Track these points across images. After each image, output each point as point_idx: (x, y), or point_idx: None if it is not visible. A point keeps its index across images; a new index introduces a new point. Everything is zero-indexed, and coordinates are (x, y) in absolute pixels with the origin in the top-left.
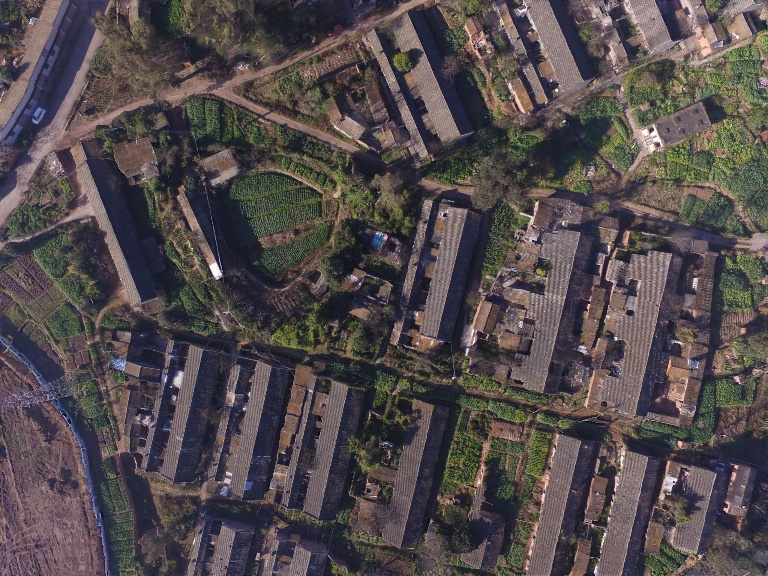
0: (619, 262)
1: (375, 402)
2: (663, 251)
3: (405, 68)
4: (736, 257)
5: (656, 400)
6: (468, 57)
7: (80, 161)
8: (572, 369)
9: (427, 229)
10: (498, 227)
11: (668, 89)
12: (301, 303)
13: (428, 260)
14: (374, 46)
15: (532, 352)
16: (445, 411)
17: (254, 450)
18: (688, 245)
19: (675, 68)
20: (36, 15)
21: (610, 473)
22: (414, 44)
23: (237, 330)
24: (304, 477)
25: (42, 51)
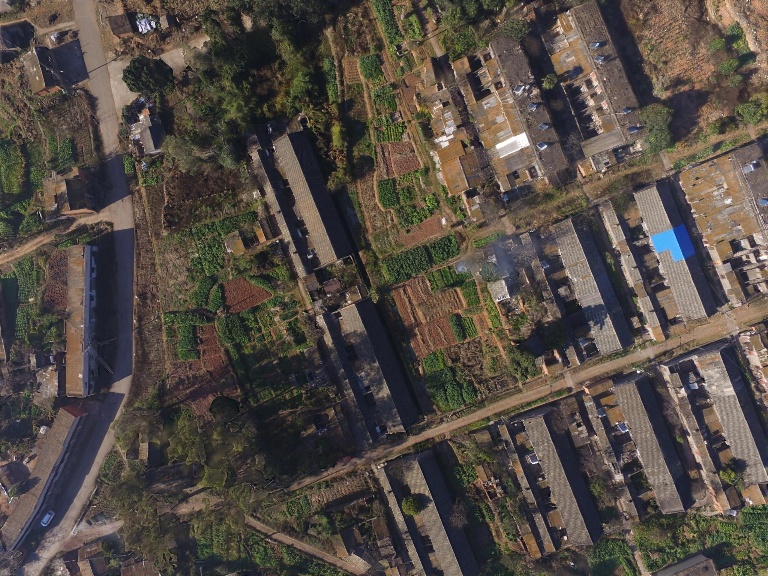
0: None
1: None
2: None
3: None
4: None
5: None
6: (477, 493)
7: (87, 575)
8: None
9: None
10: None
11: (678, 535)
12: None
13: None
14: (383, 483)
15: None
16: None
17: None
18: None
19: (686, 516)
20: (47, 421)
21: None
22: (423, 490)
23: None
24: None
25: (52, 469)
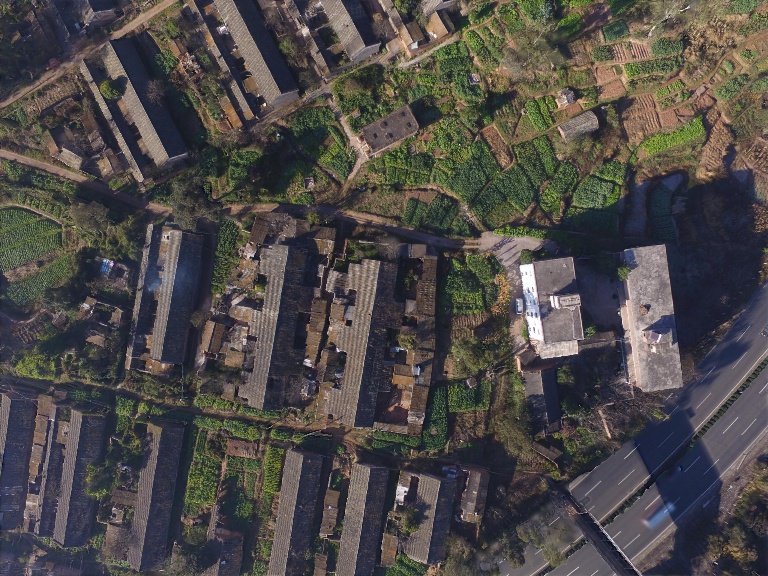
0: (335, 273)
1: (118, 427)
2: (374, 259)
3: (112, 96)
4: (465, 258)
5: (389, 409)
6: (180, 79)
7: None
8: (292, 384)
9: (150, 253)
10: (224, 245)
11: (380, 94)
12: (45, 334)
13: (156, 283)
14: (86, 76)
15: (254, 369)
16: (178, 433)
17: (1, 481)
18: (397, 251)
19: (384, 72)
20: None
21: (346, 485)
22: (119, 71)
23: None
24: (55, 505)
25: None
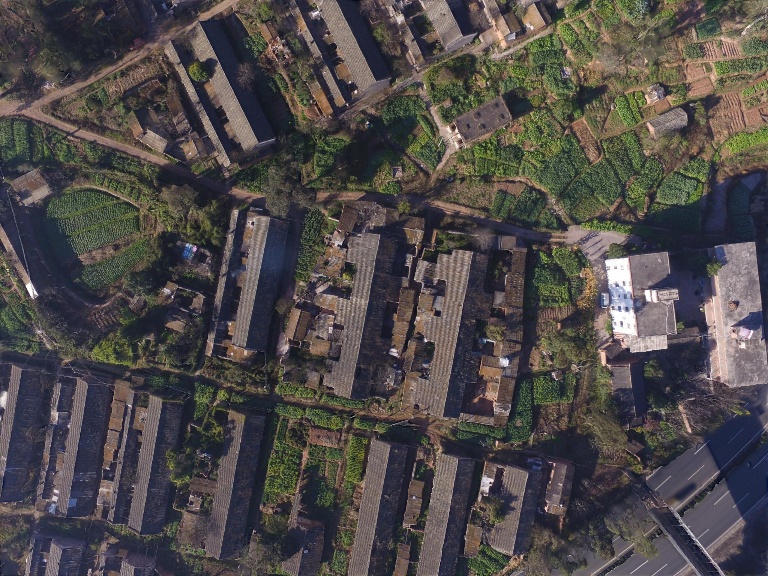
0: (425, 263)
1: (196, 414)
2: (465, 249)
3: (201, 78)
4: (551, 251)
5: (474, 400)
6: (269, 63)
7: None
8: (380, 373)
9: (235, 239)
10: (309, 233)
11: (471, 84)
12: None
13: (239, 269)
14: (172, 58)
15: (341, 358)
16: (260, 420)
17: (75, 467)
18: (490, 242)
19: (476, 62)
20: None
21: (429, 476)
22: (209, 54)
23: (59, 348)
24: (129, 492)
25: None
